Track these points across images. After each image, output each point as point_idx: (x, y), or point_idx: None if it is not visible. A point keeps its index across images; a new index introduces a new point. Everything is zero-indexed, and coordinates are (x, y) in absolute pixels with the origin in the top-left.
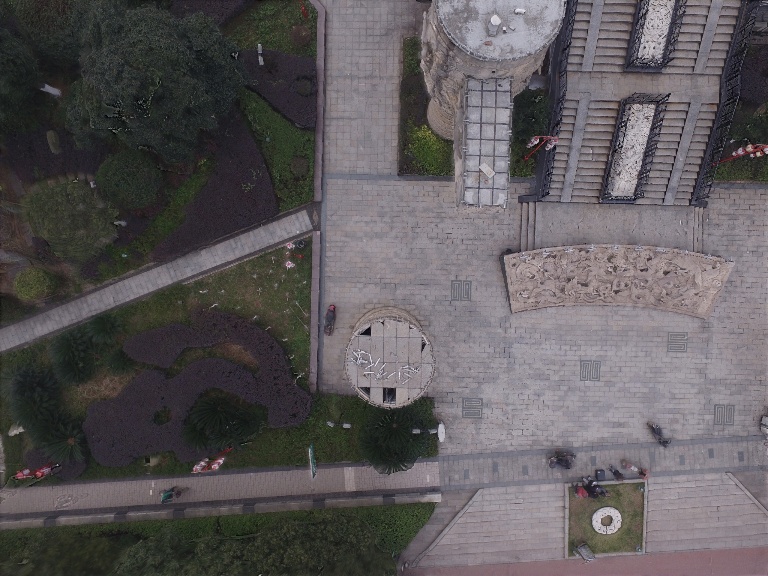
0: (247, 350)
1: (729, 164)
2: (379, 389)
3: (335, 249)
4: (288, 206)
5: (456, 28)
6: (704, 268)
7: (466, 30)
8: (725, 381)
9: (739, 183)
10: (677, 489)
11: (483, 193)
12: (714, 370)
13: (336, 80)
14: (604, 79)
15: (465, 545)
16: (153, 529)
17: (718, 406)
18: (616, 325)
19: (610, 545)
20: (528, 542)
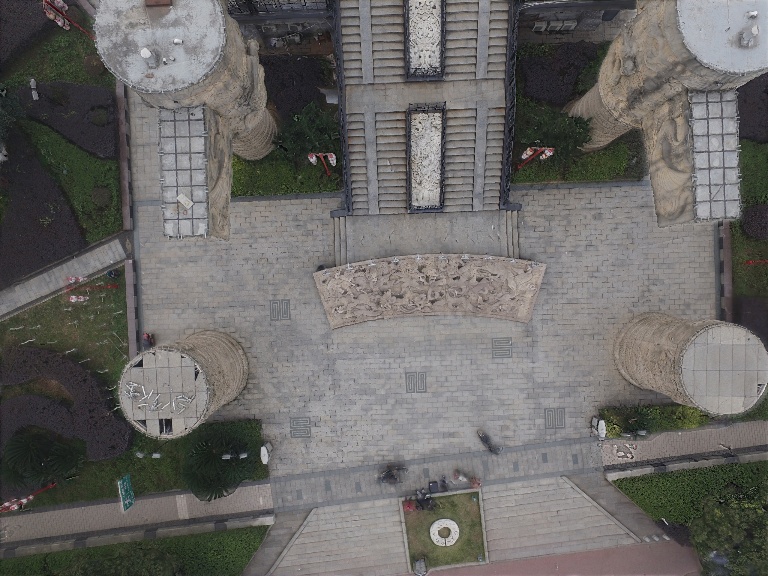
0: (62, 384)
1: (535, 166)
2: (155, 421)
3: (151, 276)
4: (94, 237)
5: (116, 62)
6: (516, 272)
7: (126, 64)
8: (553, 384)
9: (552, 183)
10: (513, 496)
11: (183, 224)
12: (541, 374)
13: (139, 107)
14: (388, 90)
15: (307, 566)
16: None
17: (548, 410)
18: (439, 335)
19: (452, 557)
20: (370, 559)
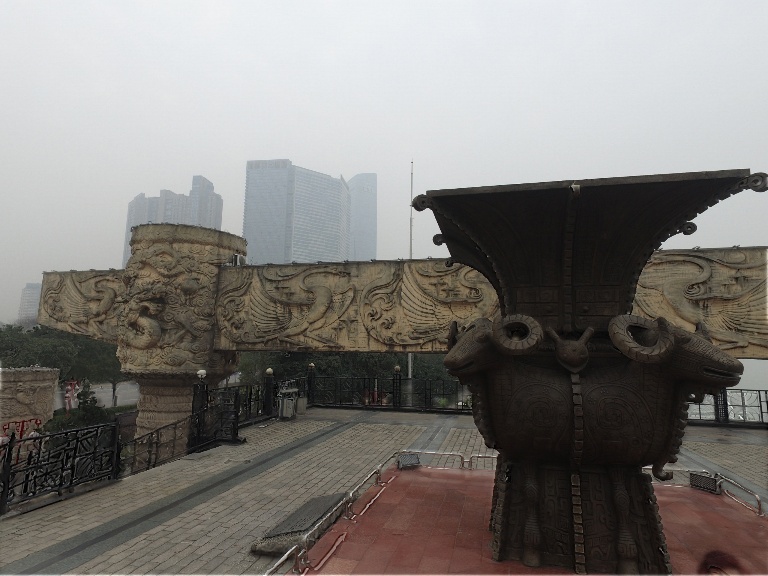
0: None
1: None
2: None
3: None
4: None
5: None
6: None
7: None
8: None
9: None
10: None
11: None
12: None
13: None
14: None
15: None
16: (68, 415)
17: None
18: None
19: None
20: None
